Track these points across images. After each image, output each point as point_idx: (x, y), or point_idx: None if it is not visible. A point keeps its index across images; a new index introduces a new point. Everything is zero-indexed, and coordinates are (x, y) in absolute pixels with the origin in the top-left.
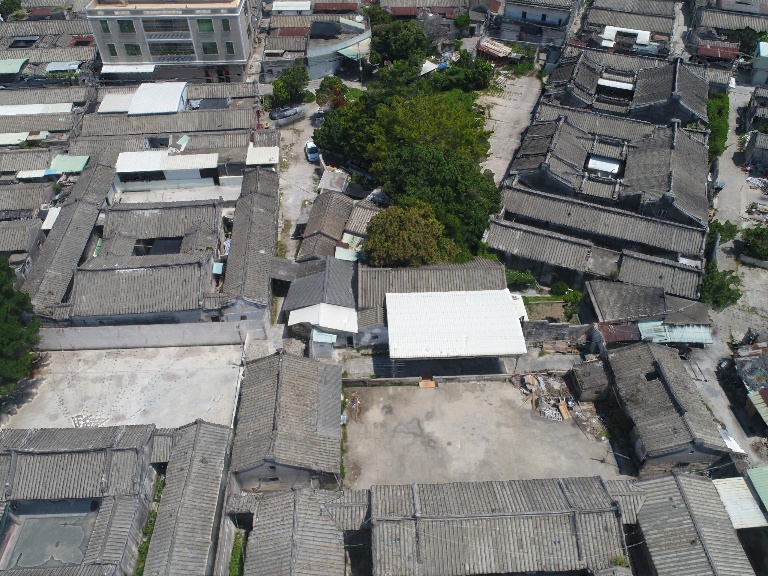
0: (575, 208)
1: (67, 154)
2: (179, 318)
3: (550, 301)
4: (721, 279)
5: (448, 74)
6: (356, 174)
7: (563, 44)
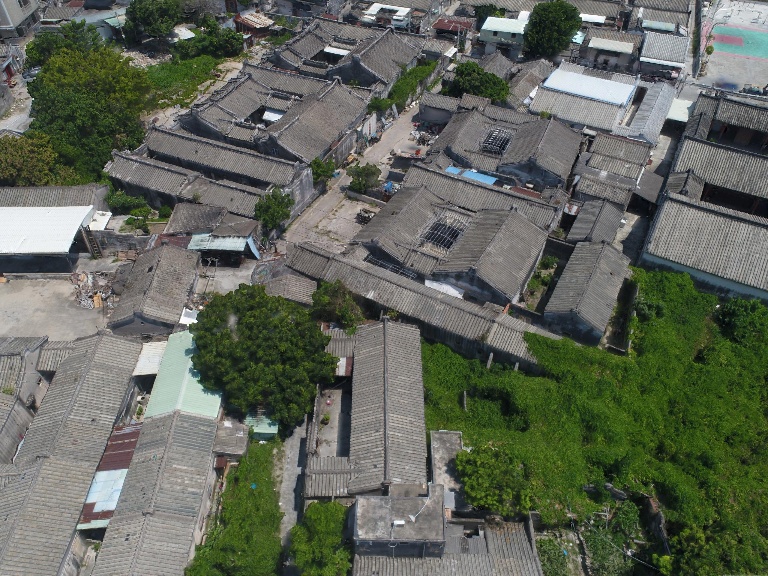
0: (203, 146)
1: None
2: None
3: (153, 222)
4: (281, 202)
5: (197, 41)
6: None
7: None
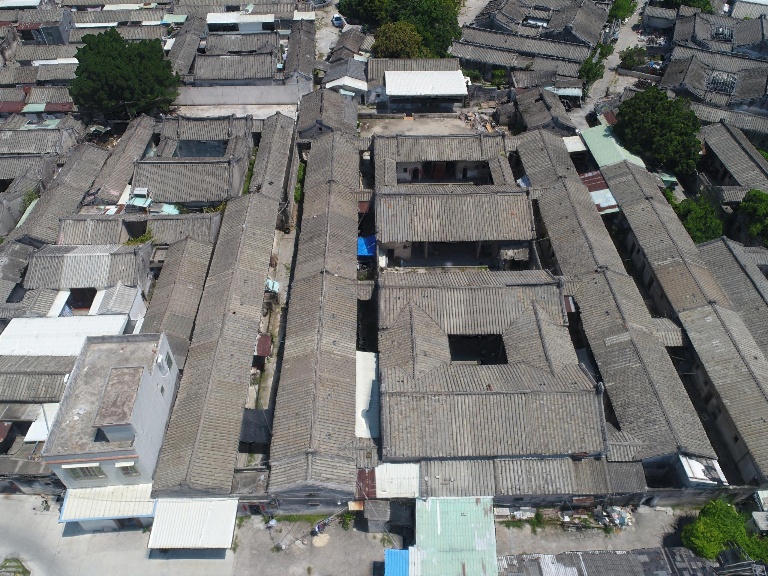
0: (510, 38)
1: (173, 14)
2: None
3: None
4: None
5: None
6: (367, 26)
7: None
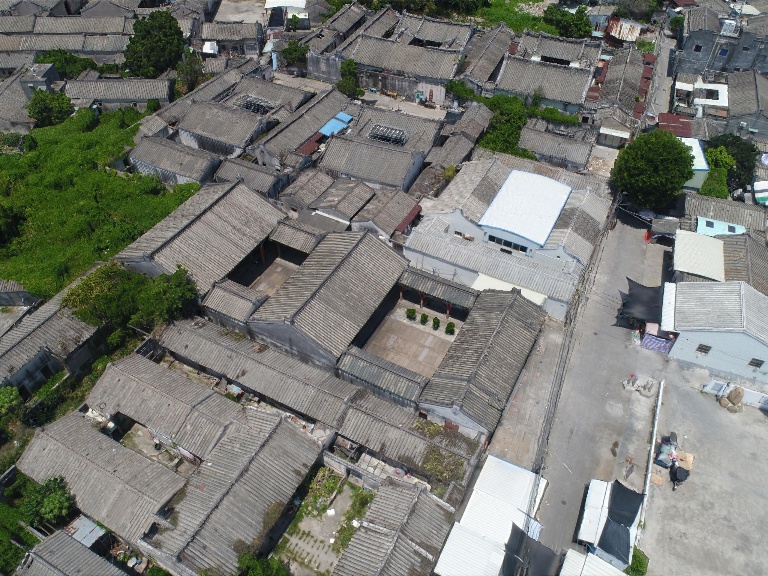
0: None
1: None
2: None
3: None
4: None
5: None
6: None
7: (676, 70)
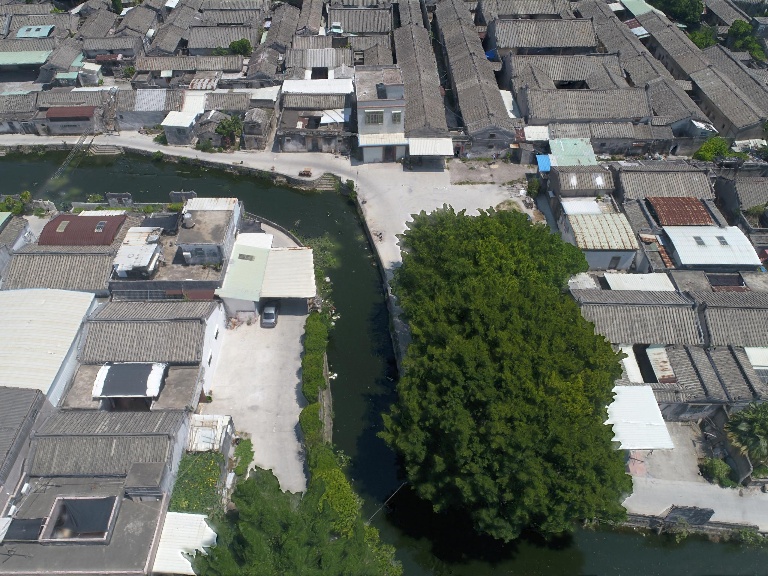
0: None
1: None
2: None
3: None
4: None
5: None
6: None
7: None
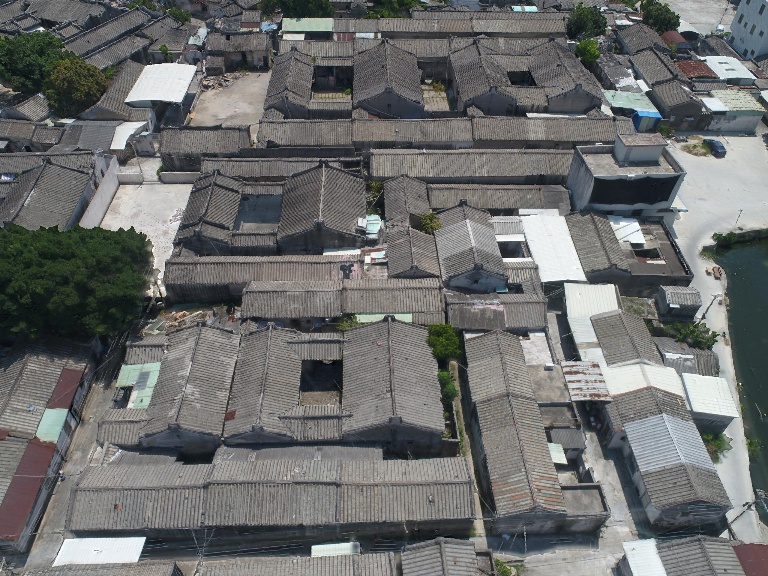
0: (85, 38)
1: None
2: (86, 197)
3: None
4: None
5: None
6: None
7: None
